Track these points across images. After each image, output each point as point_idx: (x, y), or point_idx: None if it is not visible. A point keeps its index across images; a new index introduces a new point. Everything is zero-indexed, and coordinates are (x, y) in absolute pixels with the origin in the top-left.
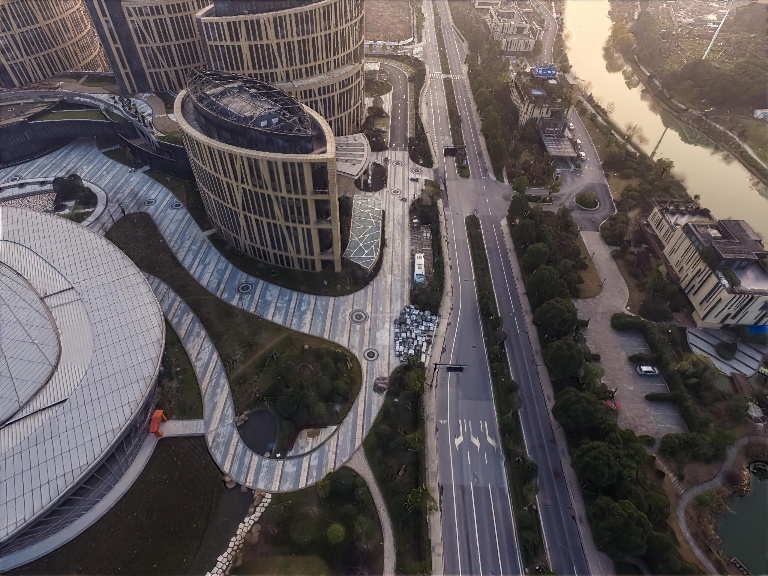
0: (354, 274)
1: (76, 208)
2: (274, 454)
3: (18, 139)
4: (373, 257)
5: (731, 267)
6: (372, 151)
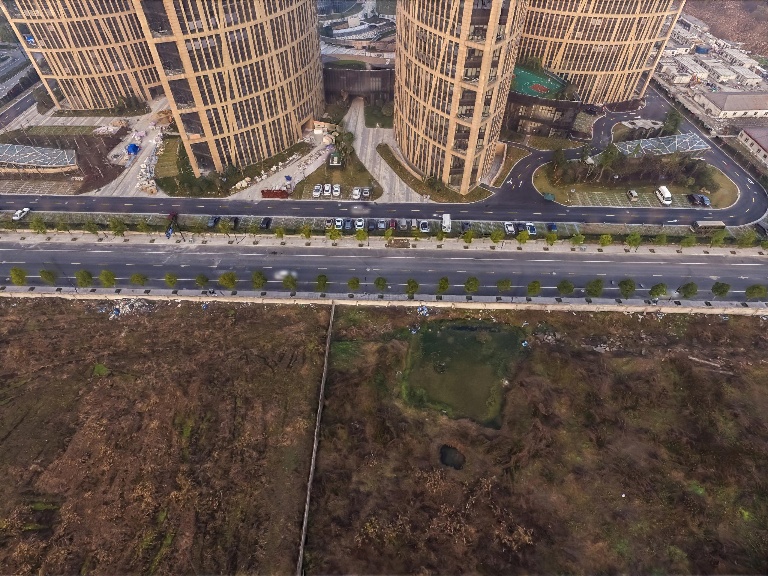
0: None
1: None
2: None
3: None
4: None
5: None
6: None
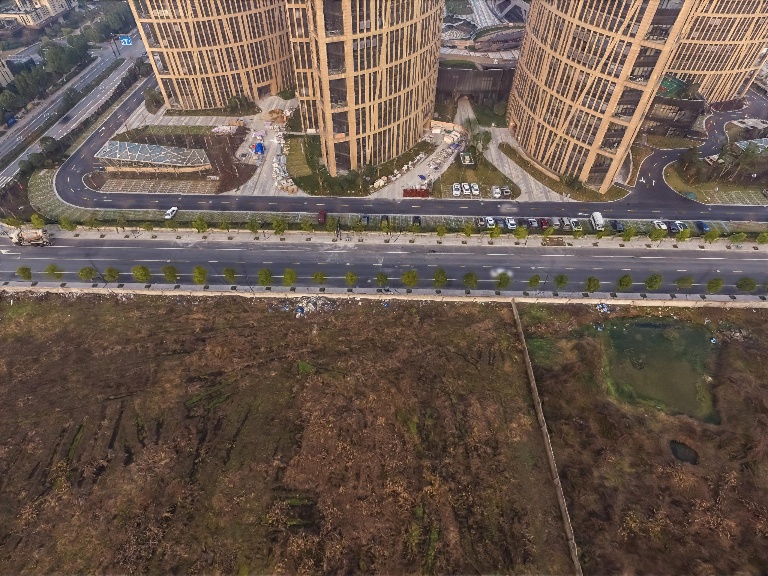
0: None
1: None
2: None
3: None
4: None
5: None
6: None
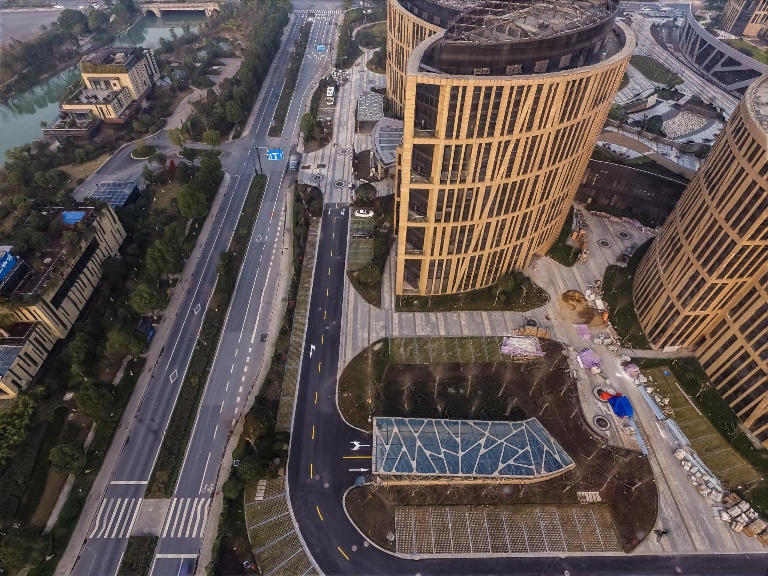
0: None
1: (614, 111)
2: None
3: None
4: (364, 93)
5: None
6: None
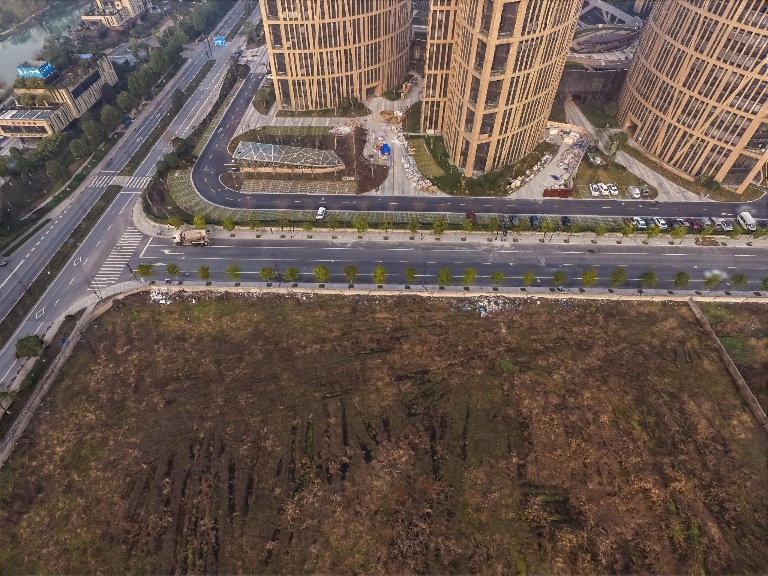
0: None
1: None
2: None
3: None
4: None
5: None
6: None
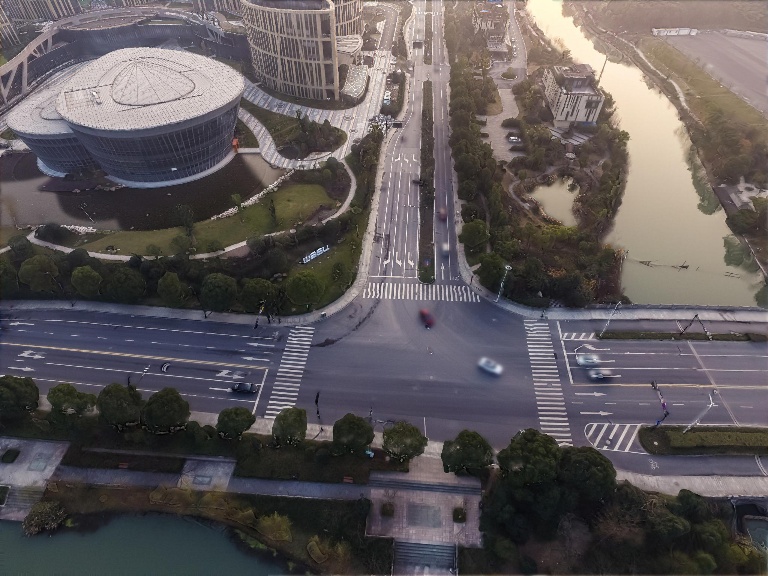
0: (347, 100)
1: None
2: (297, 159)
3: (131, 36)
4: (359, 92)
5: (572, 86)
6: (366, 50)
